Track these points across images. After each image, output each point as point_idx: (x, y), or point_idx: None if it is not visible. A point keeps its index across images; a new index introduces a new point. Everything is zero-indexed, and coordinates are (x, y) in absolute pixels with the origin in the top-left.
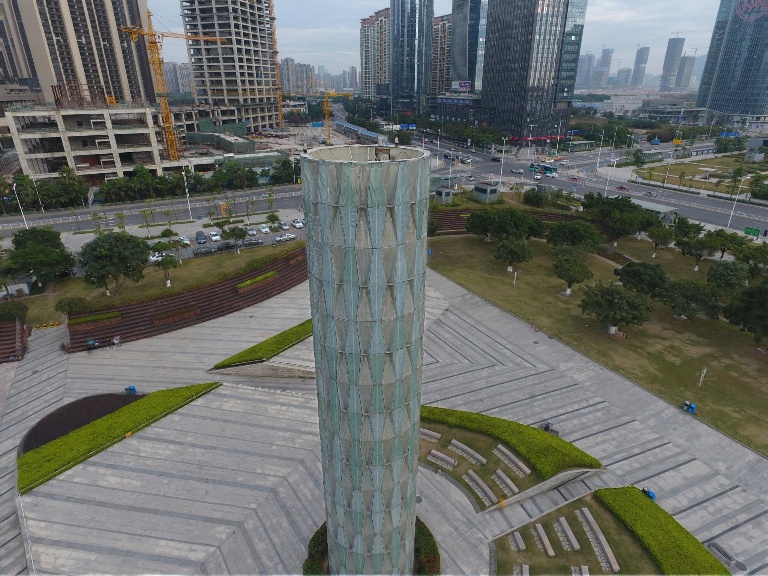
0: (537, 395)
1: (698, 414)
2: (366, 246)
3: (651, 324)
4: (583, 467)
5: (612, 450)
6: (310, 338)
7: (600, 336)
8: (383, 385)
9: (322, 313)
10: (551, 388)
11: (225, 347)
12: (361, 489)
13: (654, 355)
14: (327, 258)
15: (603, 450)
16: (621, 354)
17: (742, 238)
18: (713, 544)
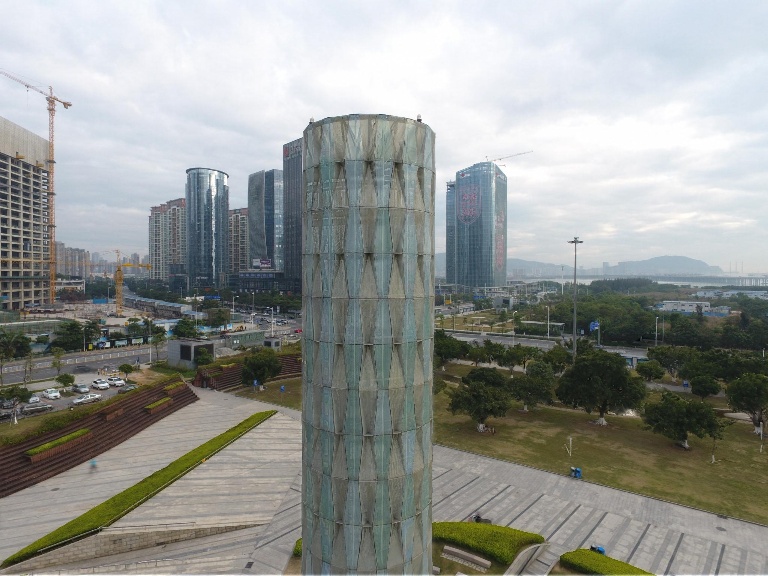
0: (450, 495)
1: (584, 477)
2: (400, 206)
3: (506, 419)
4: (532, 543)
5: (543, 524)
6: (163, 491)
7: (473, 435)
8: (414, 387)
9: (340, 299)
10: (458, 485)
11: (16, 535)
12: (387, 566)
13: (524, 441)
14: (352, 225)
15: (535, 527)
16: (499, 445)
17: (534, 349)
18: (672, 575)
